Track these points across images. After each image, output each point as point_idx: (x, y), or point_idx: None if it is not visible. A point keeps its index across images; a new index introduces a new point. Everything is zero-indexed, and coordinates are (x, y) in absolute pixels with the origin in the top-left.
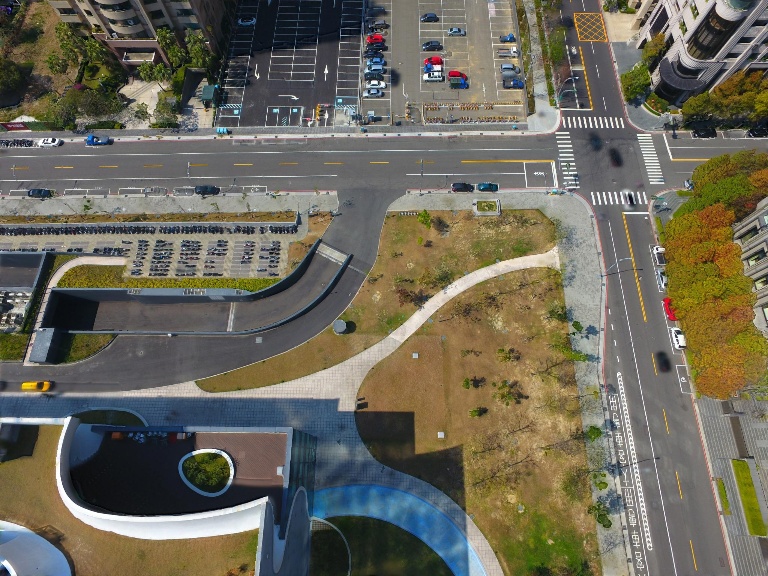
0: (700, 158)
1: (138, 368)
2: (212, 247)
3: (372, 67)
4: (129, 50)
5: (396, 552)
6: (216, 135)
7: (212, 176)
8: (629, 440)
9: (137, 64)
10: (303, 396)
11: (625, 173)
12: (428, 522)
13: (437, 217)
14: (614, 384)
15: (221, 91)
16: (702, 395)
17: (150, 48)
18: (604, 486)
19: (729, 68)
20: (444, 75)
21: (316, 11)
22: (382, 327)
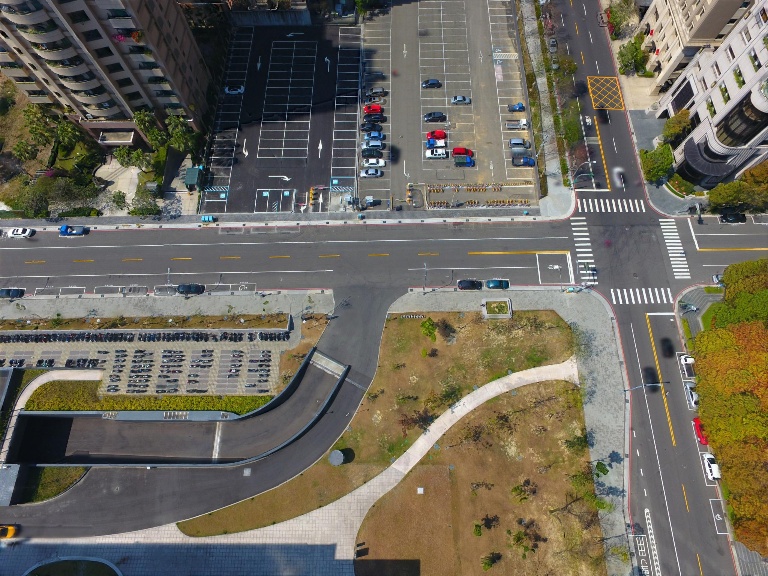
0: (729, 247)
1: (113, 507)
2: (196, 357)
3: (370, 143)
4: (106, 129)
5: None
6: (201, 223)
7: (196, 272)
8: None
9: (114, 145)
10: (296, 541)
11: (647, 266)
12: None
13: (442, 320)
14: (641, 523)
15: (206, 171)
16: None
17: (128, 128)
18: None
19: (762, 153)
20: (448, 150)
21: (309, 76)
22: (383, 455)
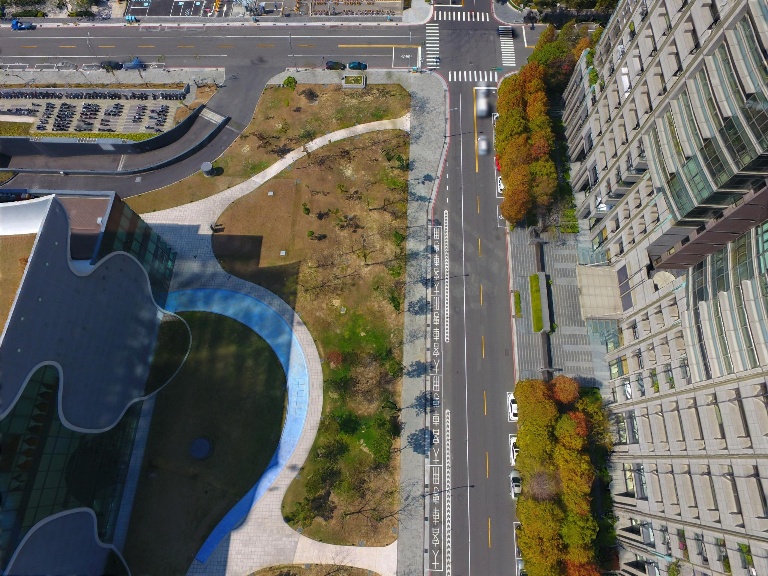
0: None
1: None
2: (110, 110)
3: None
4: None
5: (230, 338)
6: (126, 23)
7: (118, 55)
8: (445, 261)
9: None
10: (170, 222)
11: (482, 57)
12: (261, 317)
13: (309, 89)
14: (440, 219)
15: None
16: (515, 228)
17: None
18: (397, 275)
19: None
20: None
21: None
22: (246, 172)
